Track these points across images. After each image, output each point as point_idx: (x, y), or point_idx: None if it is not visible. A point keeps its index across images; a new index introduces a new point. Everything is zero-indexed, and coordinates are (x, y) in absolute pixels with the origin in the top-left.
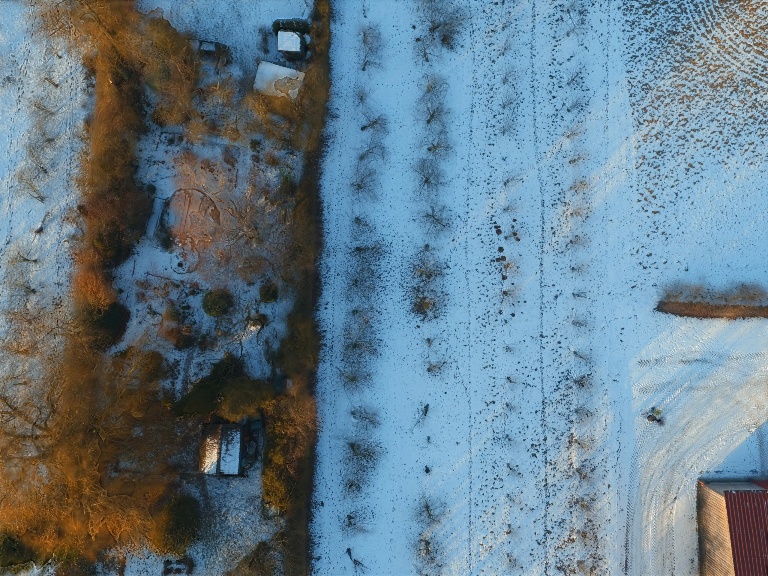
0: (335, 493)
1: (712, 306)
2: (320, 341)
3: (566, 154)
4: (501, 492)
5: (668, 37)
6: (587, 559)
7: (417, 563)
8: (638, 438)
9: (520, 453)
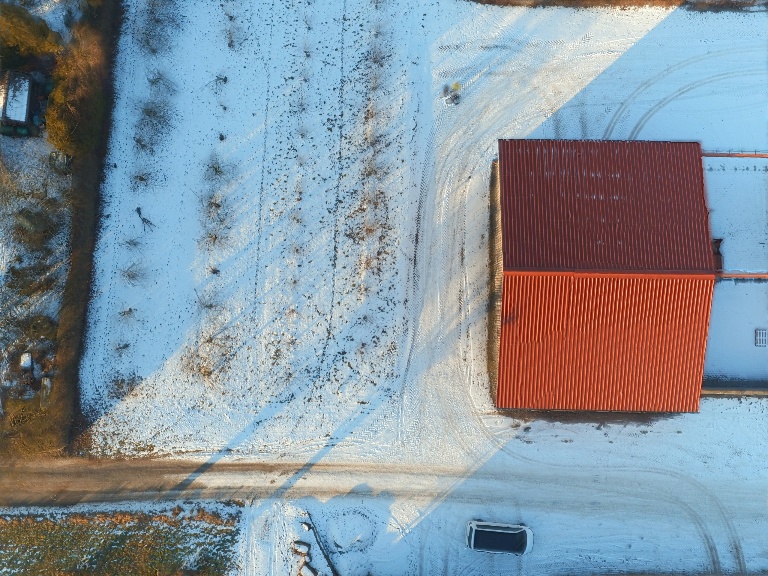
0: (128, 156)
1: None
2: (123, 14)
3: None
4: (294, 162)
5: None
6: (377, 228)
7: (206, 224)
8: (435, 120)
9: (315, 126)
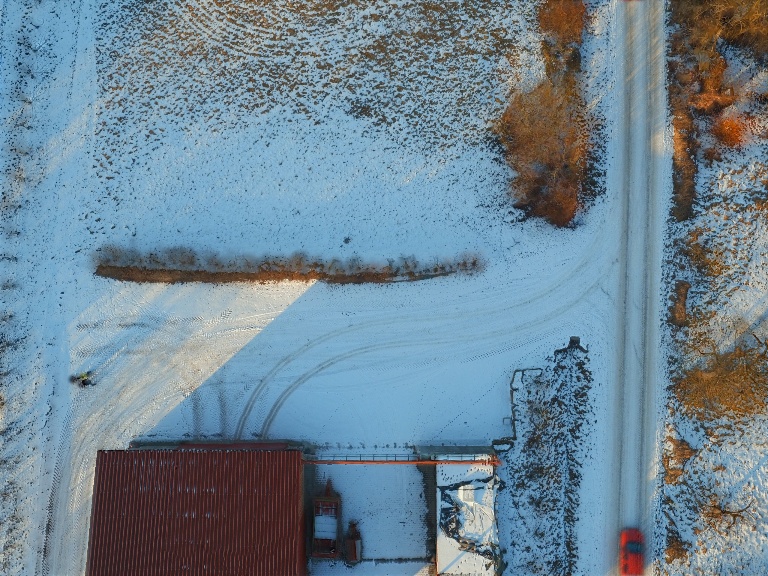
0: None
1: (148, 270)
2: None
3: (26, 120)
4: None
5: (141, 5)
6: (4, 522)
7: None
8: (72, 402)
9: None
